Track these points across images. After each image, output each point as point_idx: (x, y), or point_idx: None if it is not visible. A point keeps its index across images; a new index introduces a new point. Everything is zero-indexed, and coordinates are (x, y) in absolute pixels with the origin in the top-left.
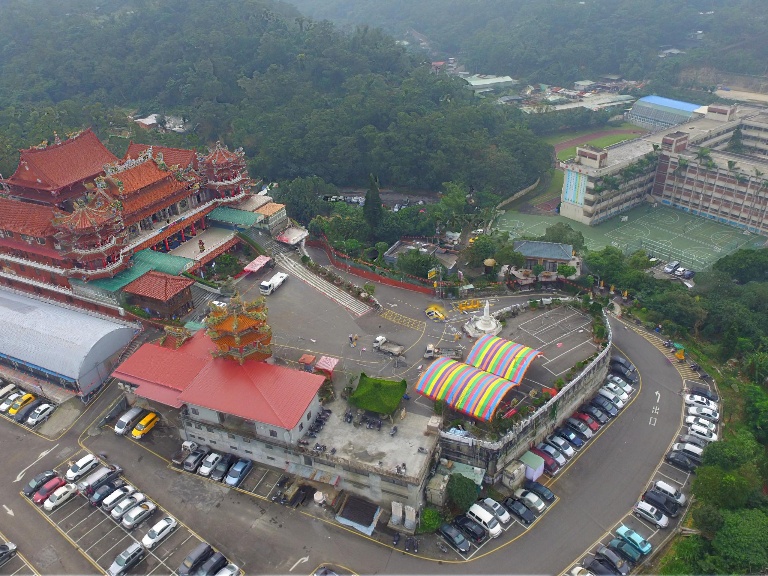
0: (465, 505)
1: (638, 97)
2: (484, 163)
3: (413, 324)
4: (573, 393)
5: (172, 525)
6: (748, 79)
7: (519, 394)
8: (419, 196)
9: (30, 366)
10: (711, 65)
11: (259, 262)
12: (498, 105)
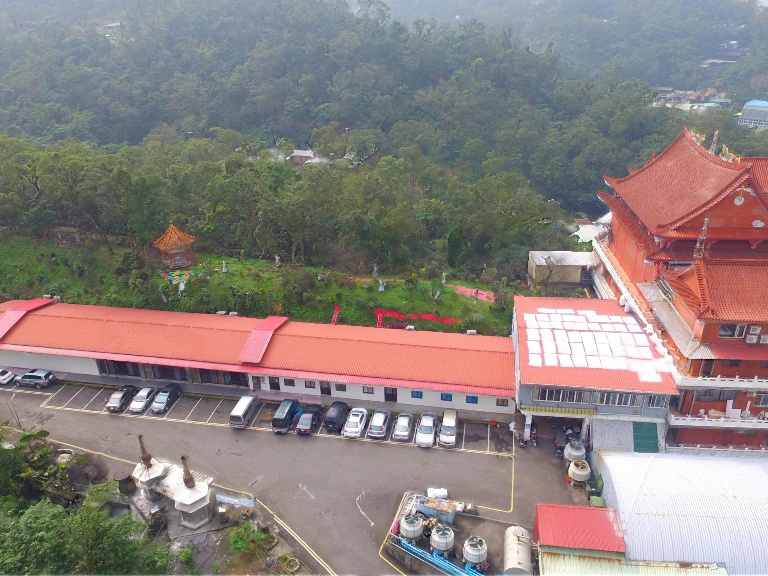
0: None
1: (738, 102)
2: None
3: None
4: None
5: None
6: None
7: None
8: None
9: None
10: None
11: None
12: None
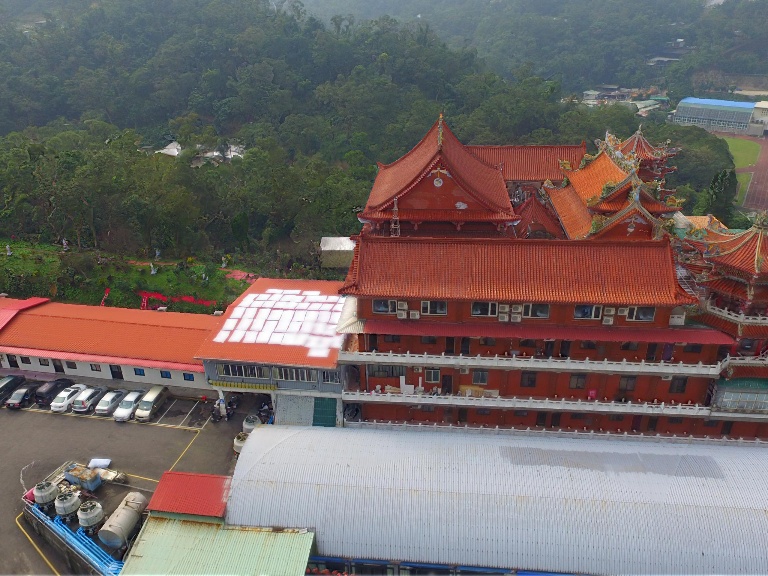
0: None
1: (674, 100)
2: (691, 162)
3: None
4: None
5: None
6: (758, 79)
7: None
8: None
9: None
10: (719, 68)
11: None
12: (627, 103)
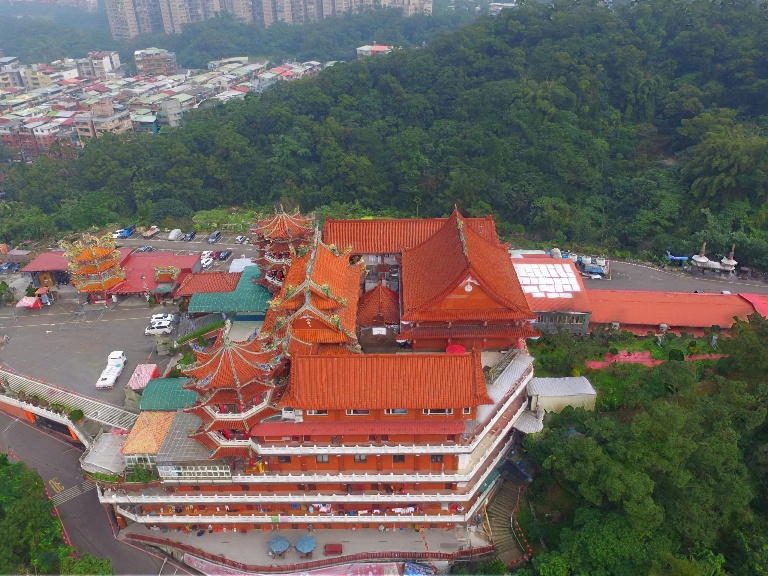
0: None
1: None
2: None
3: None
4: None
5: None
6: None
7: None
8: None
9: None
10: None
11: (140, 376)
12: None
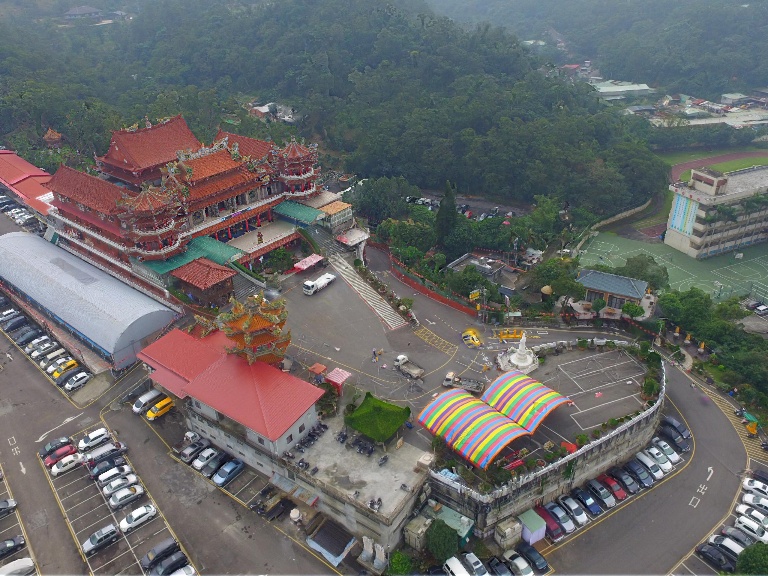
0: (441, 556)
1: None
2: (585, 178)
3: (444, 346)
4: (599, 453)
5: (150, 513)
6: None
7: (533, 444)
8: (511, 207)
9: (79, 334)
10: None
11: (310, 260)
12: (616, 116)
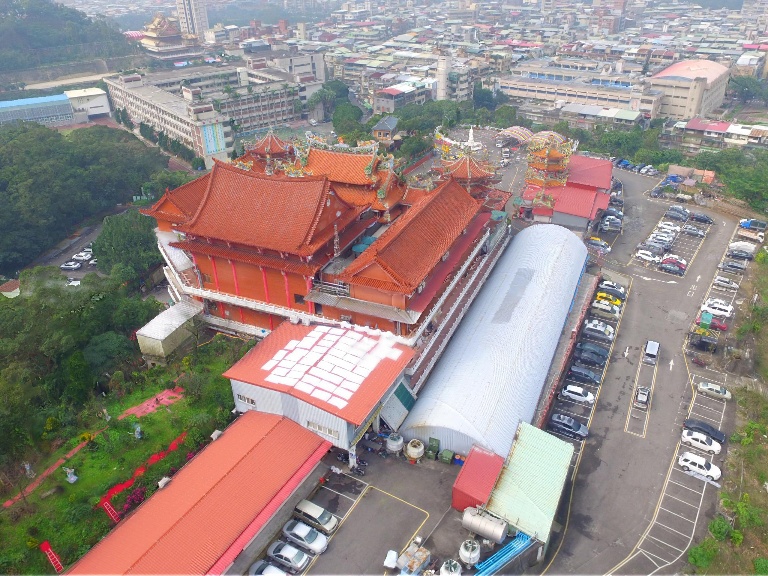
0: None
1: None
2: (135, 155)
3: None
4: None
5: None
6: (33, 72)
7: None
8: None
9: None
10: None
11: None
12: (13, 120)
